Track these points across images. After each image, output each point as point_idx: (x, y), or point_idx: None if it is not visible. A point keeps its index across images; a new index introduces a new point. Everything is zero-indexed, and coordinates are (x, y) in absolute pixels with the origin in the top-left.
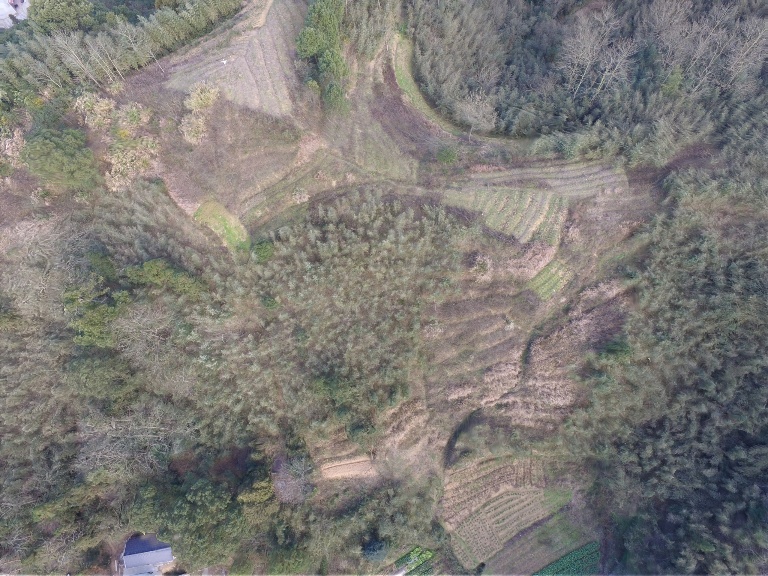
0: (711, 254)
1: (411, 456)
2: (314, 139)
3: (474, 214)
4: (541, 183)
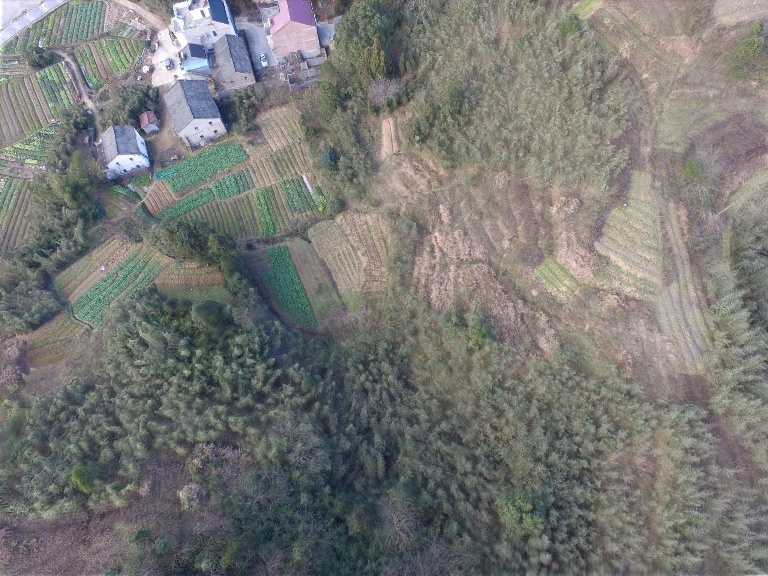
0: (595, 440)
1: (395, 183)
2: (693, 49)
3: (624, 196)
4: (671, 271)
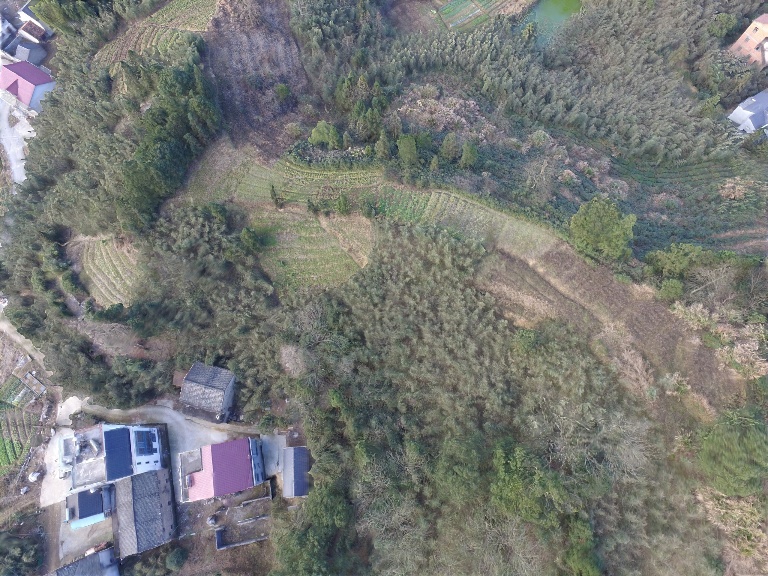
0: None
1: None
2: None
3: None
4: None
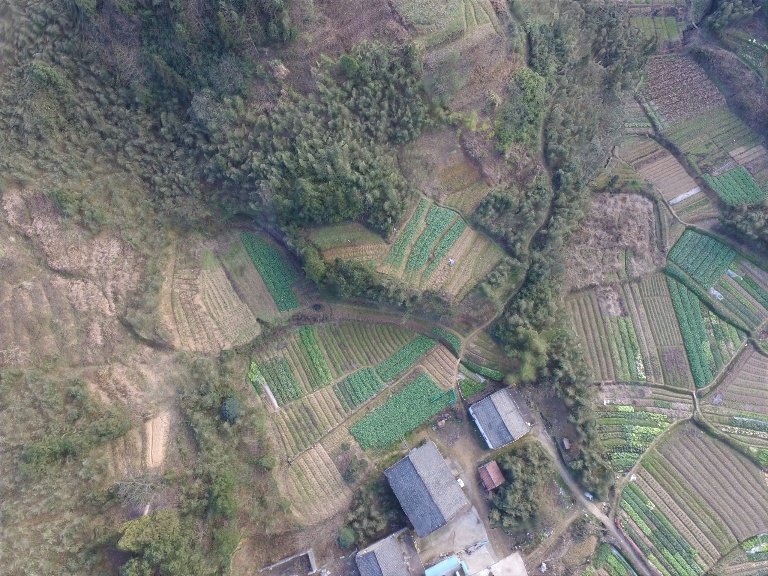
0: None
1: (155, 380)
2: None
3: None
4: None
